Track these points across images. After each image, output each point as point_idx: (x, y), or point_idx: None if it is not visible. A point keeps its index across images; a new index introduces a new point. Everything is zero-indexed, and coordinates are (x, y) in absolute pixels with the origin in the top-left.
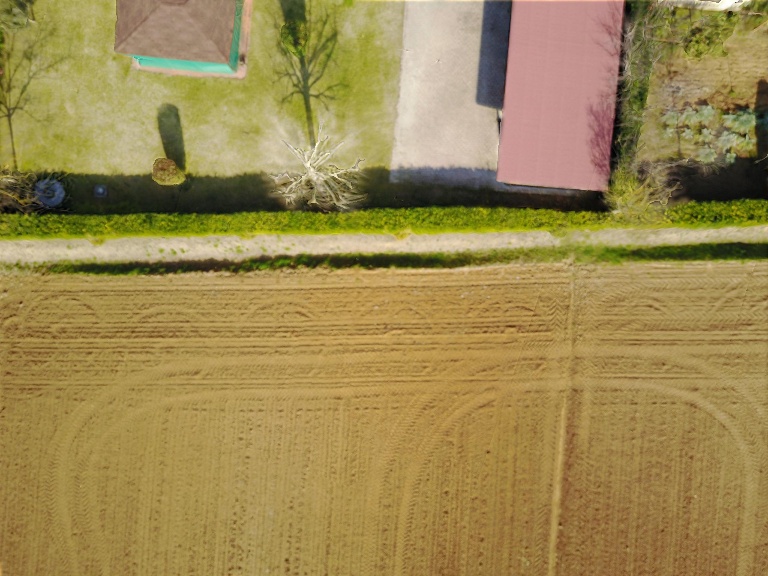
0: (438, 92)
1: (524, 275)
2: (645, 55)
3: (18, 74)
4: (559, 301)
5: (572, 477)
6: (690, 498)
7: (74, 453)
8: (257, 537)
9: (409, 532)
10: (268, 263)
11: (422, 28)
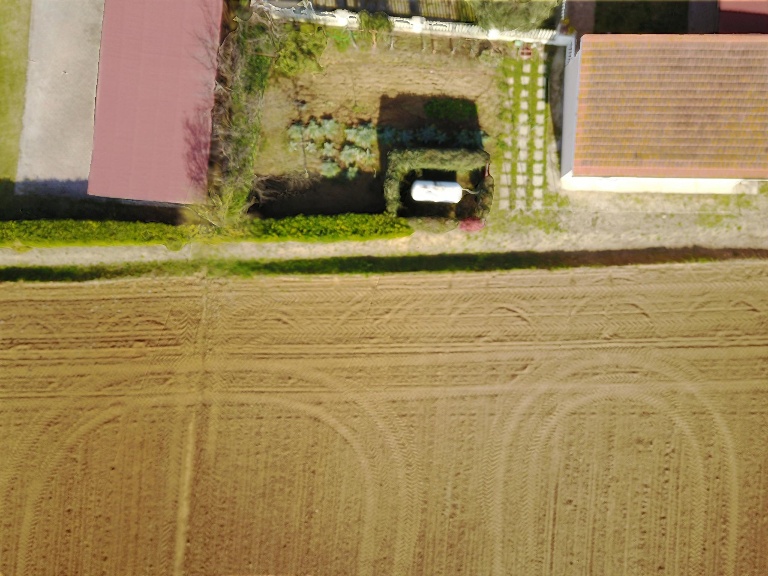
0: (64, 103)
1: (156, 289)
2: (251, 69)
3: None
4: (190, 315)
5: (199, 493)
6: (311, 513)
7: None
8: None
9: (30, 552)
10: None
11: (48, 39)
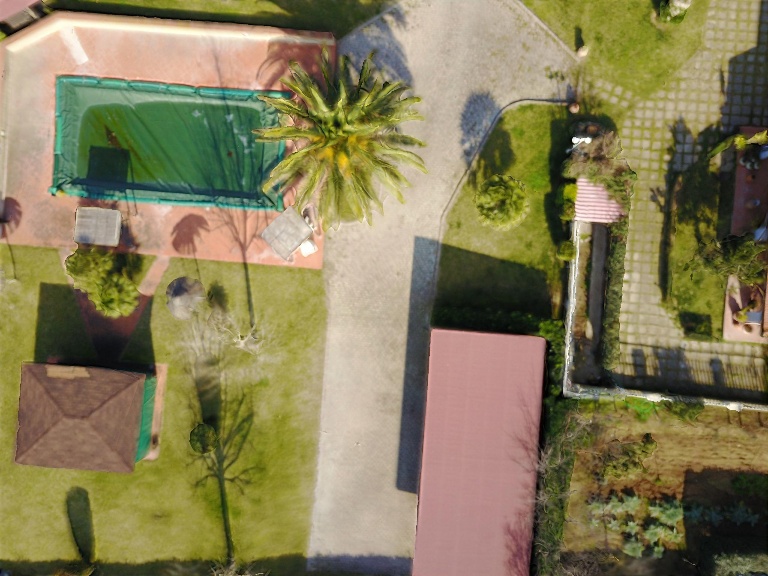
0: (357, 476)
1: None
2: (565, 461)
3: None
4: None
5: None
6: None
7: None
8: None
9: None
10: None
11: (341, 409)
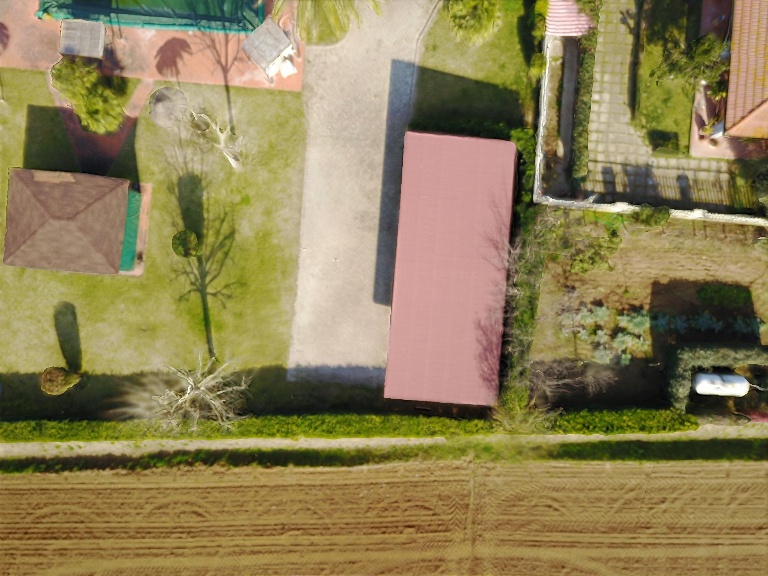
0: (335, 290)
1: (423, 473)
2: (535, 265)
3: None
4: (459, 500)
5: None
6: None
7: None
8: None
9: None
10: (166, 460)
11: (319, 226)
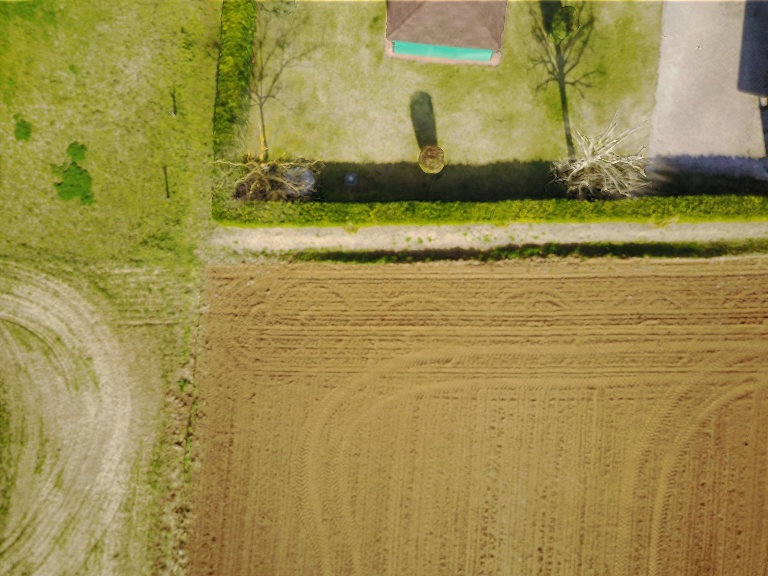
0: (698, 79)
1: None
2: None
3: (271, 63)
4: None
5: None
6: None
7: (325, 439)
8: (509, 526)
9: (664, 524)
10: (517, 252)
11: (682, 14)
